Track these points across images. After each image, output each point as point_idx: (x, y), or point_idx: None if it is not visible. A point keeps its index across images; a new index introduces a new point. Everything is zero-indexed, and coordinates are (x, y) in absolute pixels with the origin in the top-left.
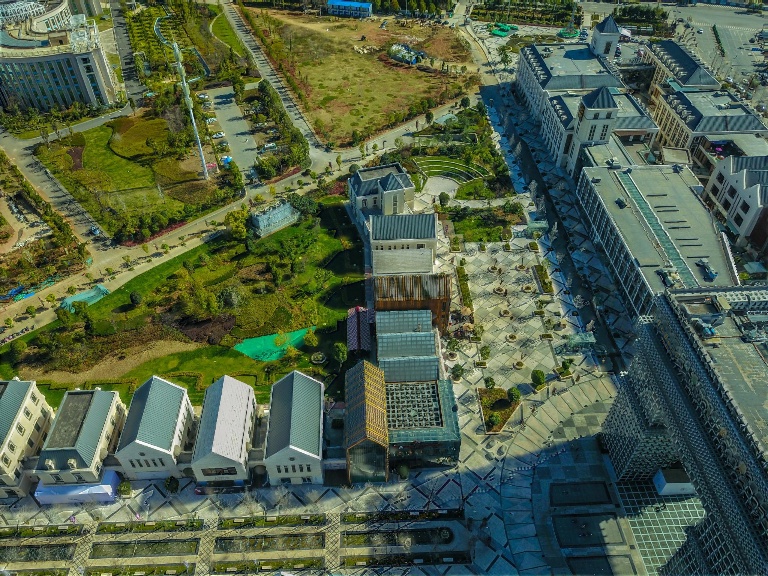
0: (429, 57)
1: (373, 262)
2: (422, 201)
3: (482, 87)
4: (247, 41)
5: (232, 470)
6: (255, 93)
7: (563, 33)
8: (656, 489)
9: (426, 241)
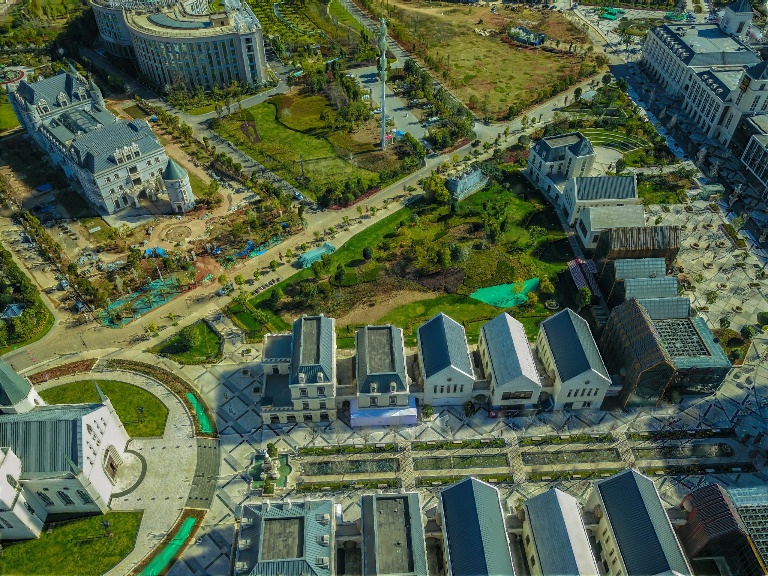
0: (549, 39)
1: (590, 218)
2: (594, 169)
3: (611, 66)
4: (368, 25)
5: (528, 394)
6: (397, 72)
7: (670, 16)
8: None
9: (627, 201)
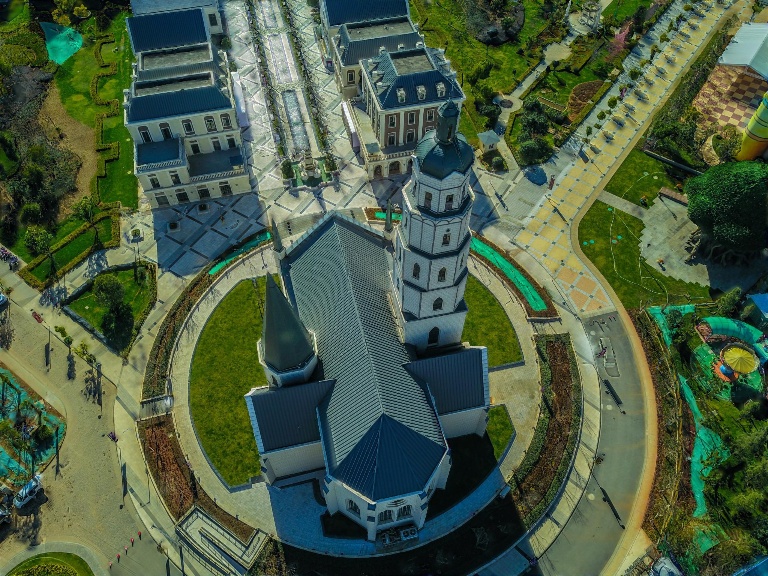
0: None
1: None
2: None
3: None
4: None
5: None
6: None
7: None
8: None
9: None
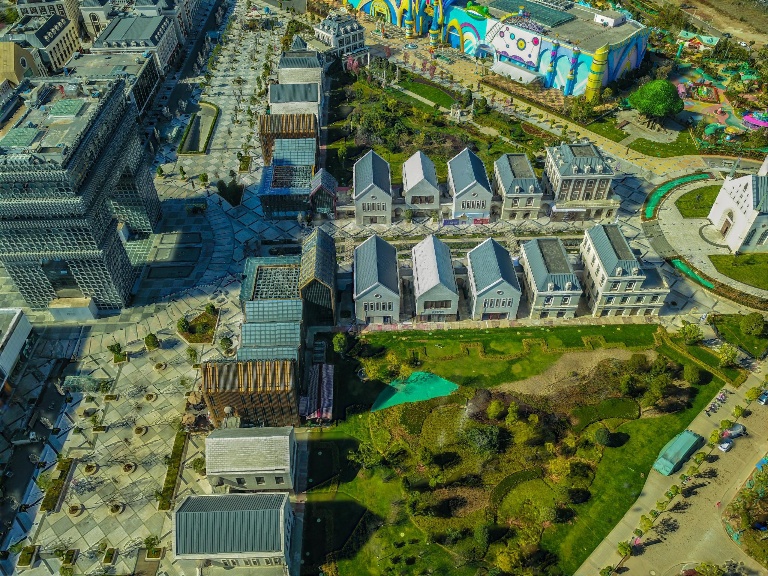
0: None
1: None
2: None
3: None
4: None
5: None
6: None
7: None
8: None
9: None
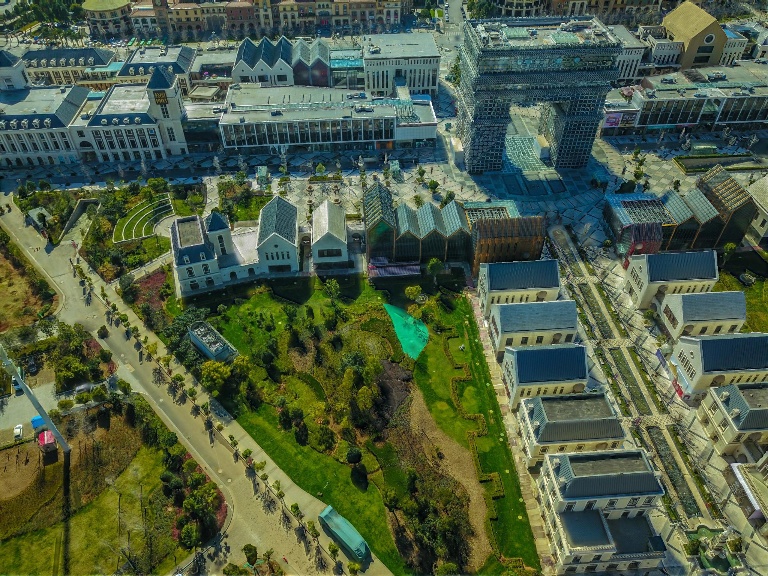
0: None
1: (337, 237)
2: None
3: None
4: None
5: None
6: None
7: None
8: (502, 160)
9: None
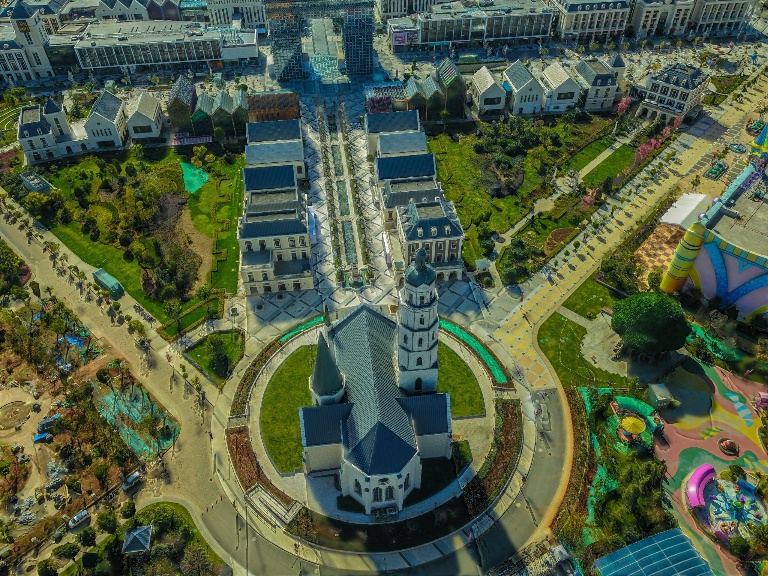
0: None
1: (145, 115)
2: None
3: None
4: None
5: None
6: None
7: None
8: (308, 71)
9: (123, 105)
